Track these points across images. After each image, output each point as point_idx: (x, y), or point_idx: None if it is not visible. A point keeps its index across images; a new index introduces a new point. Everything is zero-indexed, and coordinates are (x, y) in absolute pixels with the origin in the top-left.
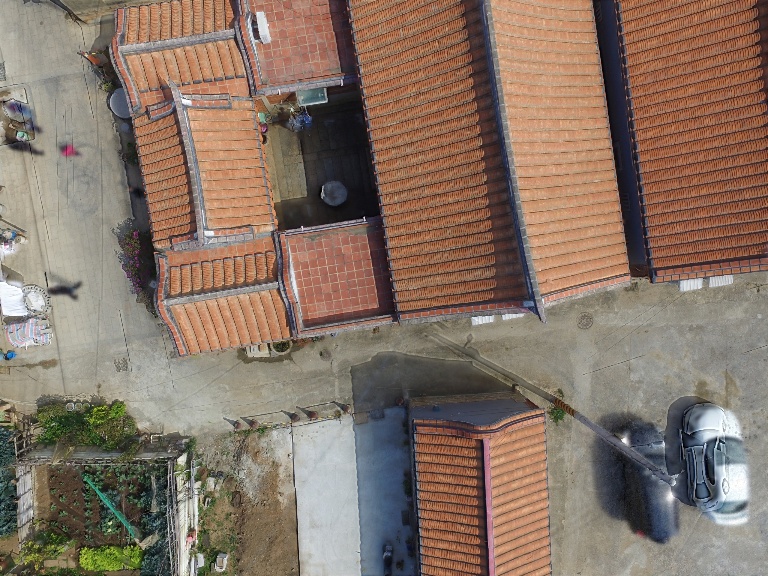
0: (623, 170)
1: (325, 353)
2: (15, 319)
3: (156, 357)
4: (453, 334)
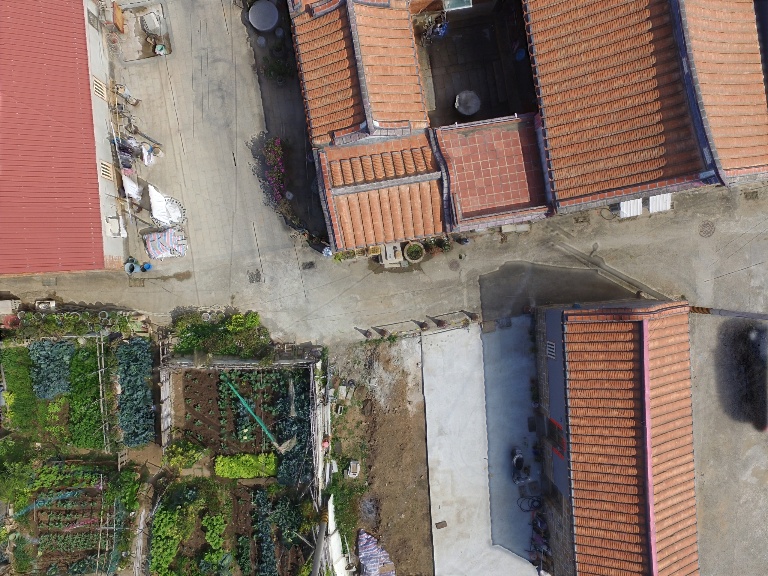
0: None
1: (454, 263)
2: (151, 231)
3: (288, 268)
4: (579, 243)
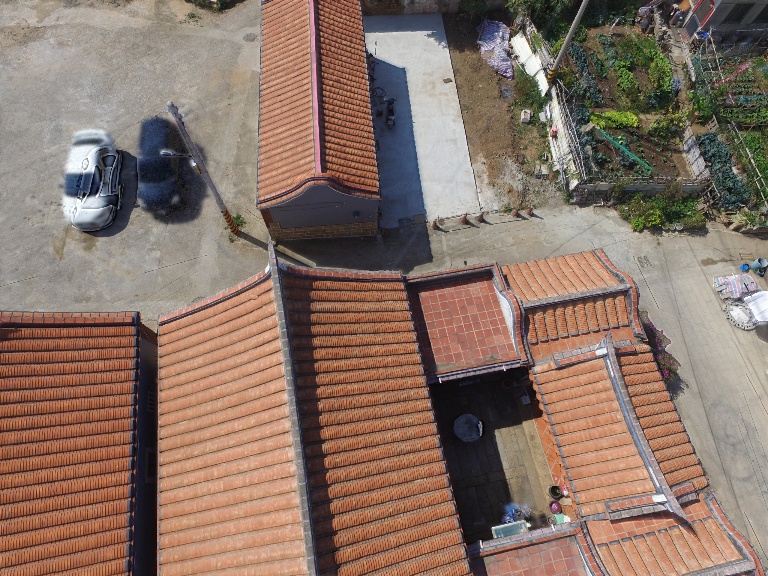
0: (146, 445)
1: None
2: None
3: None
4: None
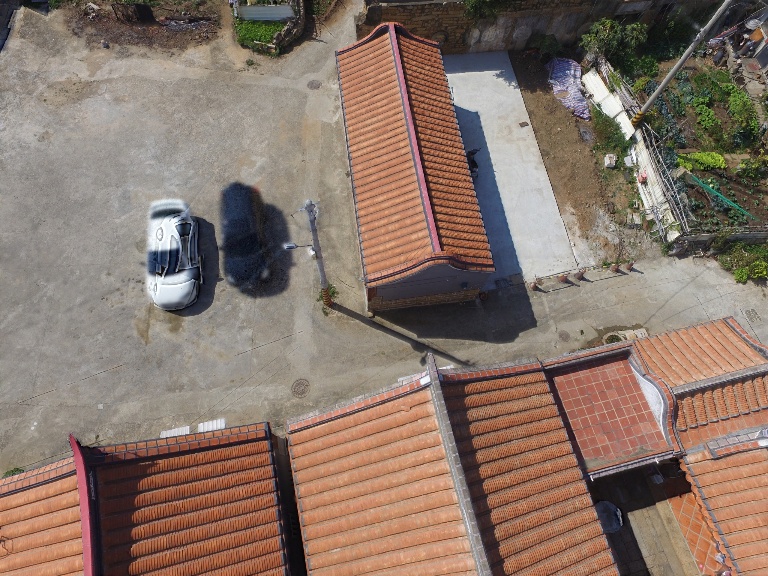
0: None
1: (565, 338)
2: None
3: None
4: (441, 365)
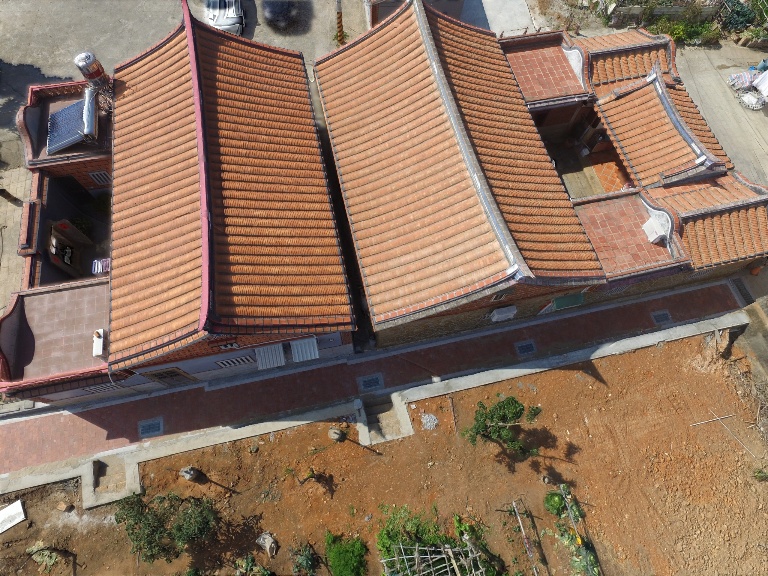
0: None
1: None
2: None
3: None
4: None
